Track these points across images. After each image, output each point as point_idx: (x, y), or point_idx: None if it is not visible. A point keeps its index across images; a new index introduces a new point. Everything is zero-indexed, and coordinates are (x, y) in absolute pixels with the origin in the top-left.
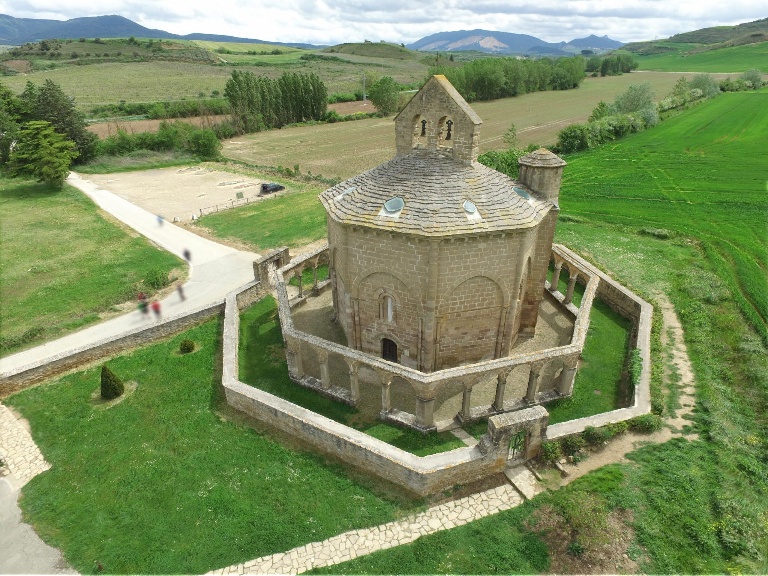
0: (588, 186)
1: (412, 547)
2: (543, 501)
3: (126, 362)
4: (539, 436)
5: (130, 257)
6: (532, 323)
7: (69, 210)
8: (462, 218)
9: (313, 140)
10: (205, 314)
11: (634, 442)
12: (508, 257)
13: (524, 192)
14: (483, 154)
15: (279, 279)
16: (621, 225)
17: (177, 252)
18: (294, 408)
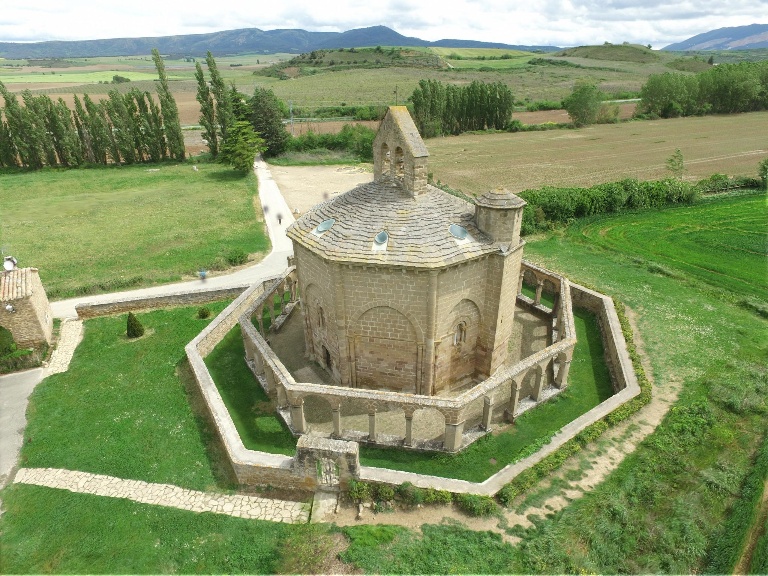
0: (738, 234)
1: (194, 515)
2: (318, 530)
3: (162, 315)
4: (348, 471)
5: (239, 237)
6: (486, 371)
7: (237, 193)
8: (366, 247)
9: (478, 149)
10: (236, 292)
11: (446, 517)
12: (416, 294)
13: (464, 231)
14: (652, 180)
15: (281, 275)
16: (721, 289)
17: (274, 238)
18: (207, 379)
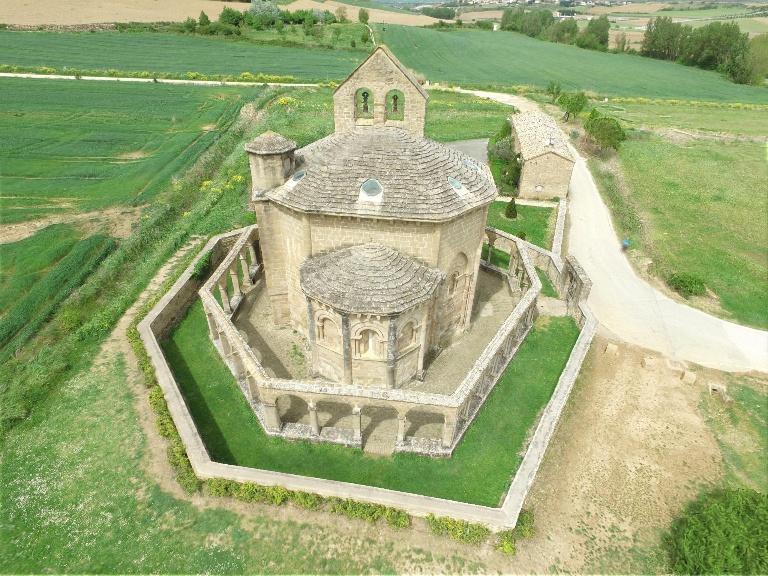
0: None
1: None
2: None
3: (536, 225)
4: None
5: None
6: None
7: None
8: None
9: None
10: None
11: None
12: None
13: None
14: None
15: None
16: None
17: None
18: None
